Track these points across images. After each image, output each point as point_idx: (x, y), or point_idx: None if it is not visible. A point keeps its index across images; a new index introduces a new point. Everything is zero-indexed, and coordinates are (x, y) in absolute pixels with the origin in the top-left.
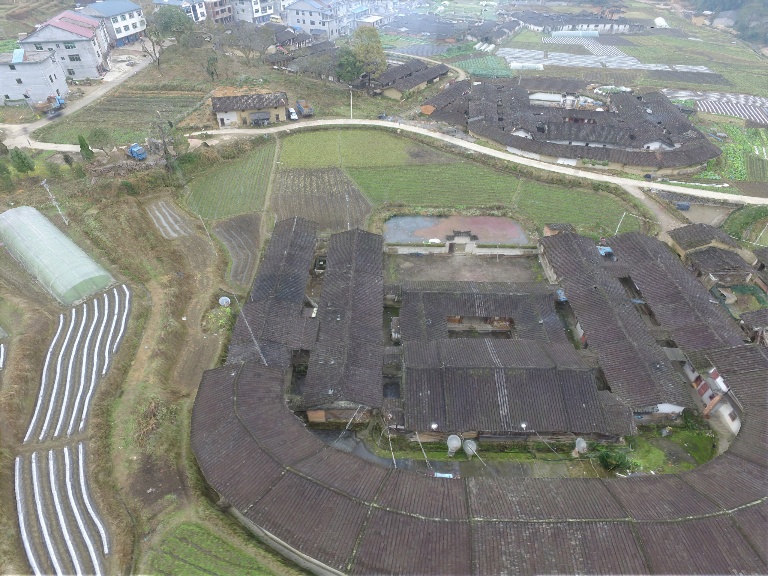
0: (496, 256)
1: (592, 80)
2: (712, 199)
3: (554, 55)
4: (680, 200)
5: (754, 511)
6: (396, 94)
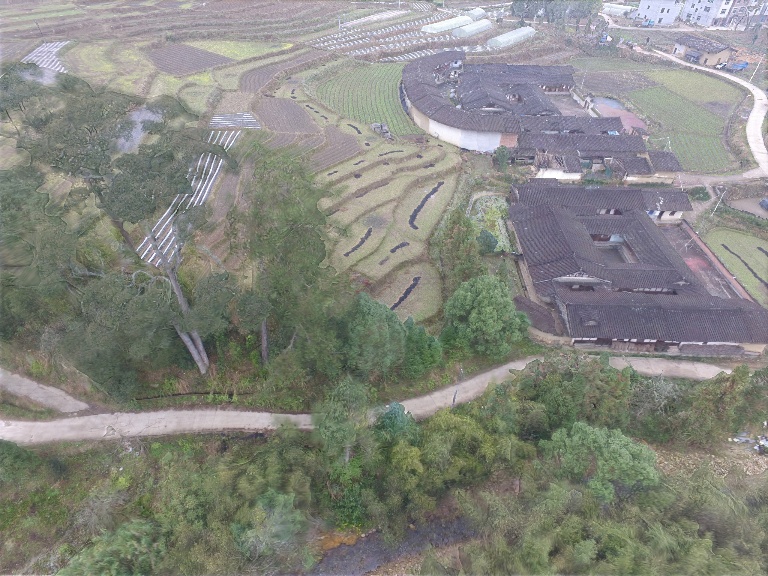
0: None
1: None
2: None
3: None
4: None
5: None
6: None
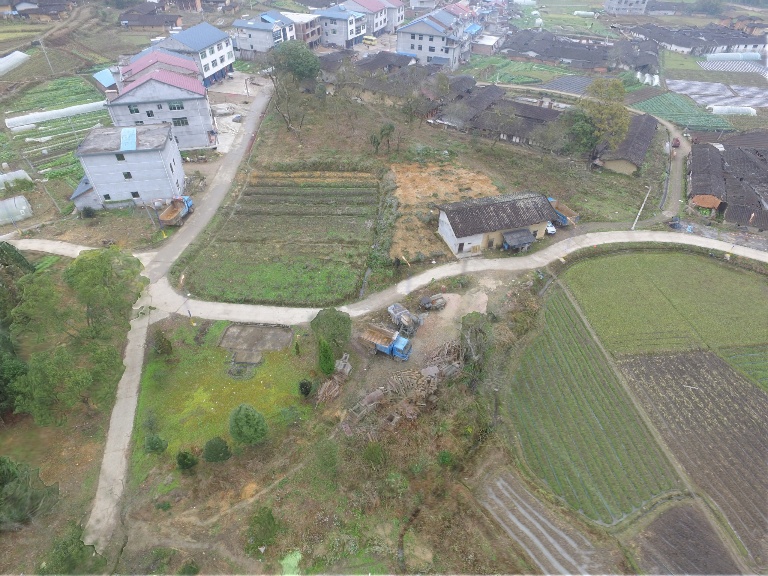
0: None
1: None
2: None
3: (741, 90)
4: None
5: None
6: (626, 167)
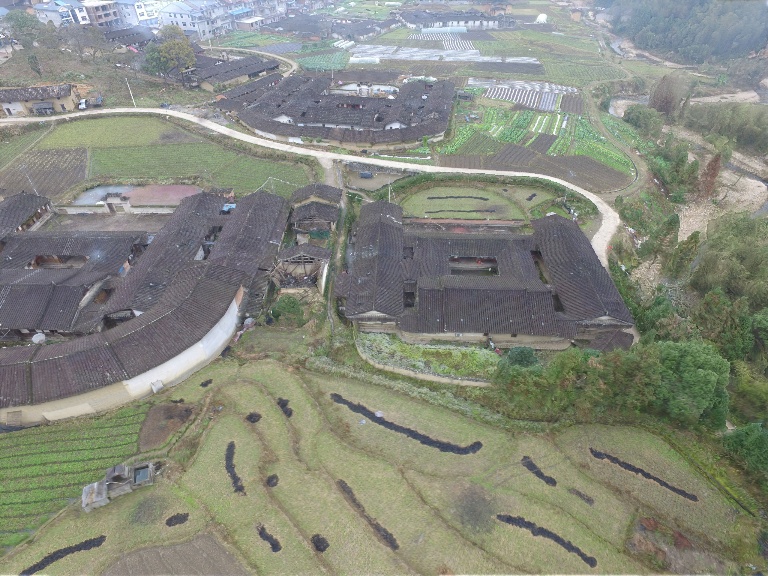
0: (150, 214)
1: (409, 71)
2: (394, 168)
3: (404, 50)
4: (370, 170)
5: (53, 362)
6: (209, 87)
